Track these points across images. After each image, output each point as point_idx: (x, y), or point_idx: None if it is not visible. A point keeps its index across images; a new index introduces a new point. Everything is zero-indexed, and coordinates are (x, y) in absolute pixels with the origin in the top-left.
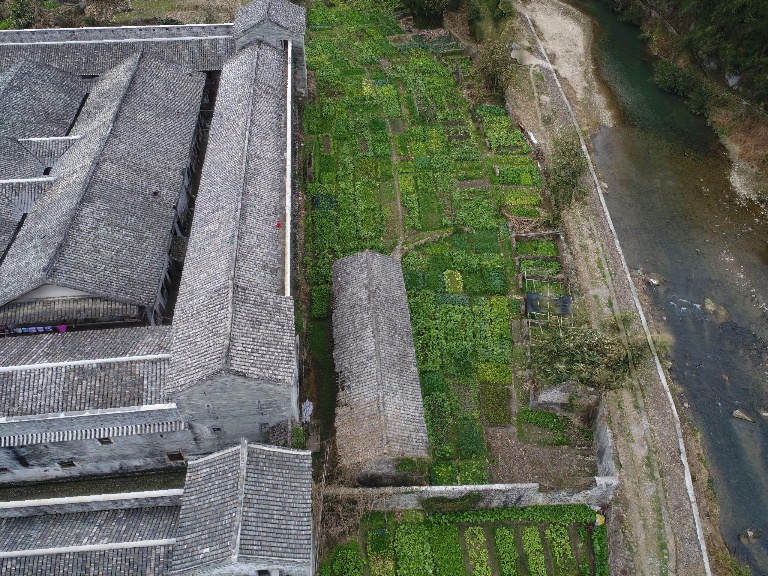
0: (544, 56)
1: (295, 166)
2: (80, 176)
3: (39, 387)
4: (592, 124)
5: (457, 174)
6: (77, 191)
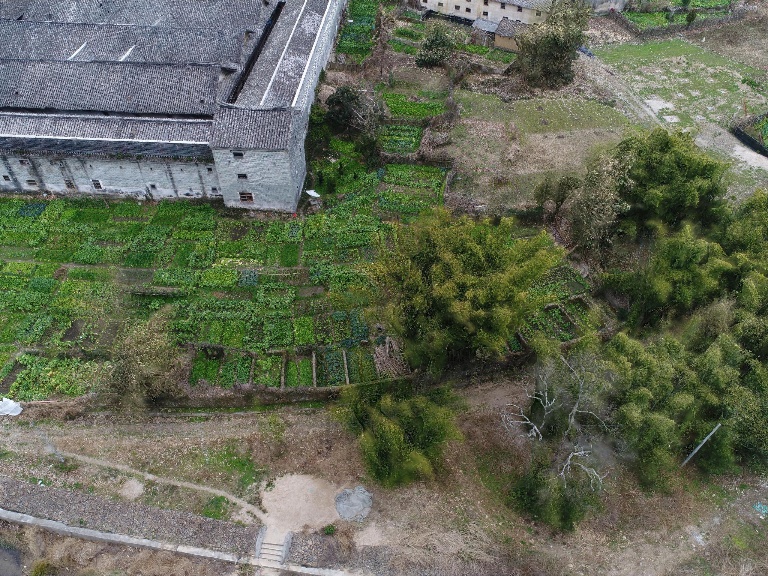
0: (313, 566)
1: (3, 152)
2: None
3: None
4: (40, 561)
5: (3, 313)
6: None
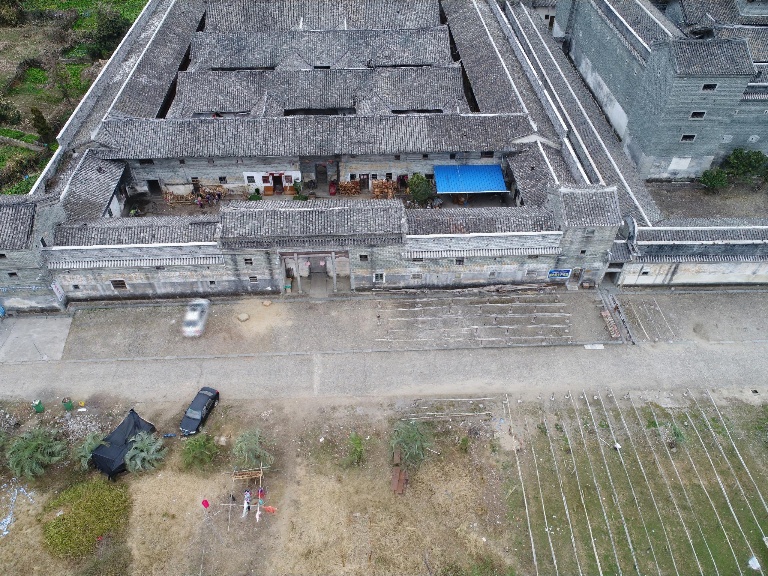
0: None
1: None
2: (355, 5)
3: (481, 6)
4: None
5: None
6: (369, 3)
